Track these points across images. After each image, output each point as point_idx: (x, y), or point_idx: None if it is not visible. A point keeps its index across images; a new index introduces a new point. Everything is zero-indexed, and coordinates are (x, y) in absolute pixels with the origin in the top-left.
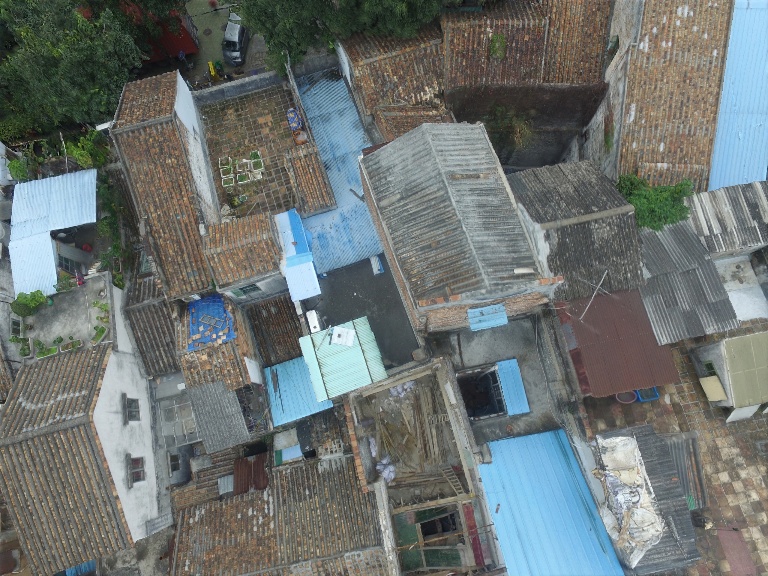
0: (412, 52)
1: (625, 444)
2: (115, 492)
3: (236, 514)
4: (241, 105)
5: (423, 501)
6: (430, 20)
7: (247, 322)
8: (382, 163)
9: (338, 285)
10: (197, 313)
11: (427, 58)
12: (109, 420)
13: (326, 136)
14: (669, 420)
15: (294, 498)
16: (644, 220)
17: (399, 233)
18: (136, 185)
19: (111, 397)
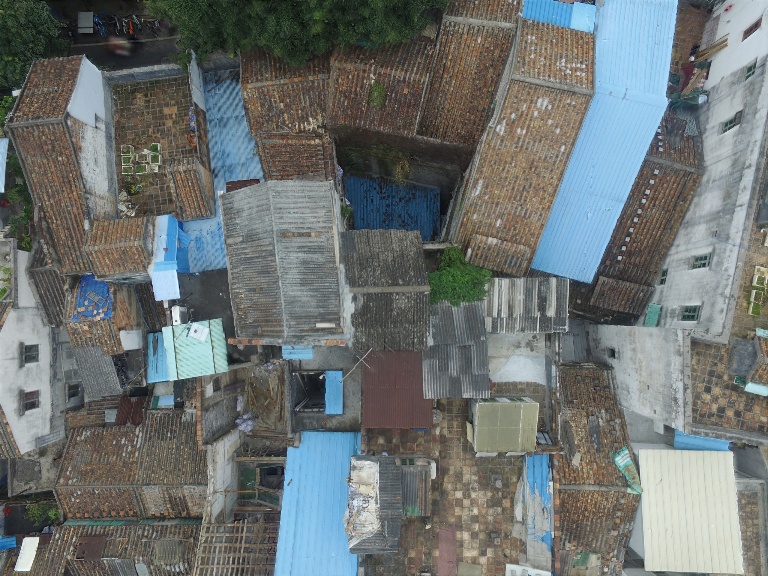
0: (300, 82)
1: (370, 467)
2: (5, 420)
3: (112, 440)
4: (151, 90)
5: (265, 453)
6: (320, 54)
7: (134, 296)
8: (235, 204)
9: (208, 284)
10: (86, 288)
11: (314, 90)
12: (4, 366)
13: (220, 142)
14: (433, 446)
15: (158, 437)
16: (447, 295)
17: (237, 270)
18: (31, 175)
19: (8, 347)
